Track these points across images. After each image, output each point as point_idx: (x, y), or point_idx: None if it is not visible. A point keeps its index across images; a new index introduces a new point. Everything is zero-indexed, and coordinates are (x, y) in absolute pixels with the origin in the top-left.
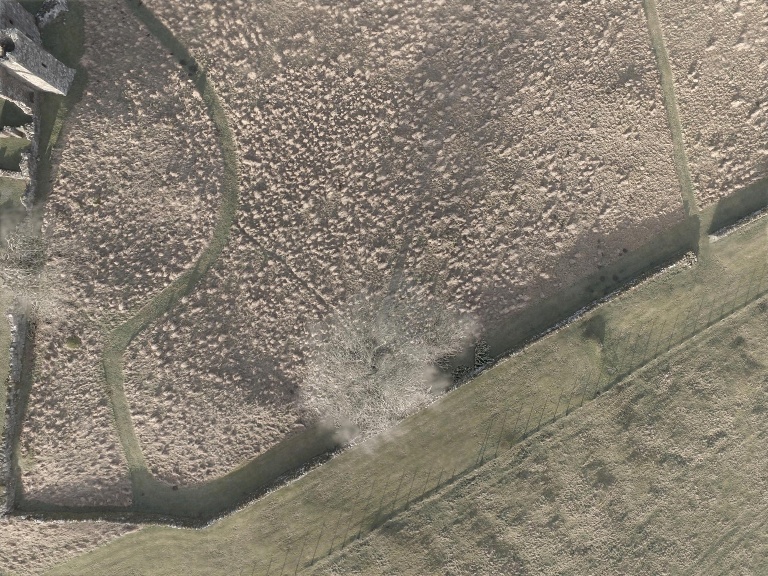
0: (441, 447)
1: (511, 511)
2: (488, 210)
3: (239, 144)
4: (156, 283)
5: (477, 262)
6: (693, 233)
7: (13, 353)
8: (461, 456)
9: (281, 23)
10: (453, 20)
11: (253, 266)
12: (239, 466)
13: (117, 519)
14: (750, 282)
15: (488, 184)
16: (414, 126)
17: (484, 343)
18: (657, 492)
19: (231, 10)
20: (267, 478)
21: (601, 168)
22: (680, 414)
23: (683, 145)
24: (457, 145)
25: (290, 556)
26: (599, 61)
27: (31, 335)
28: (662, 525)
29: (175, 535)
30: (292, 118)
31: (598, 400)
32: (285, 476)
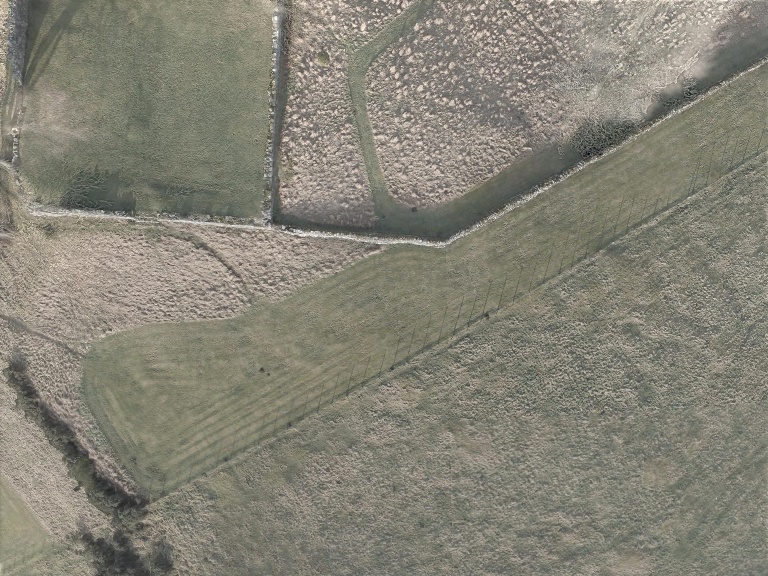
0: (657, 175)
1: (721, 240)
2: None
3: None
4: (390, 9)
5: (681, 1)
6: None
7: (276, 58)
8: (675, 184)
9: None
10: None
11: None
12: (474, 187)
13: (366, 234)
14: None
15: None
16: None
17: (691, 77)
18: None
19: None
20: (500, 200)
21: None
22: None
23: None
24: None
25: (524, 274)
26: None
27: (285, 49)
28: None
29: (415, 255)
30: None
31: None
32: (519, 194)
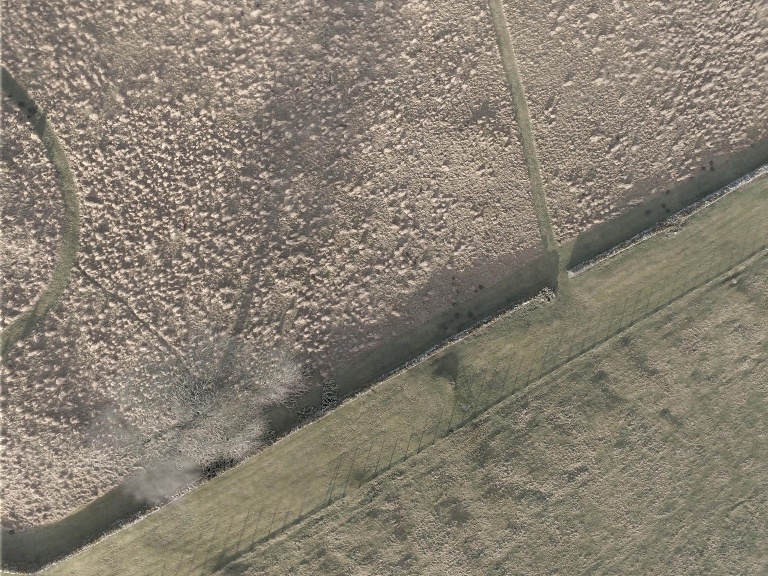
0: (287, 487)
1: (361, 550)
2: (337, 249)
3: (80, 186)
4: None
5: (326, 301)
6: (552, 268)
7: None
8: (308, 496)
9: (125, 63)
10: (302, 59)
11: (94, 308)
12: (76, 510)
13: None
14: (612, 316)
15: (337, 223)
16: (261, 165)
17: (332, 382)
18: (515, 528)
19: (73, 51)
20: (105, 521)
21: (455, 205)
22: (539, 449)
23: (541, 181)
24: (305, 184)
25: None
26: (452, 98)
27: None
28: (521, 561)
29: None
30: (136, 159)
31: (451, 437)
32: (122, 520)
